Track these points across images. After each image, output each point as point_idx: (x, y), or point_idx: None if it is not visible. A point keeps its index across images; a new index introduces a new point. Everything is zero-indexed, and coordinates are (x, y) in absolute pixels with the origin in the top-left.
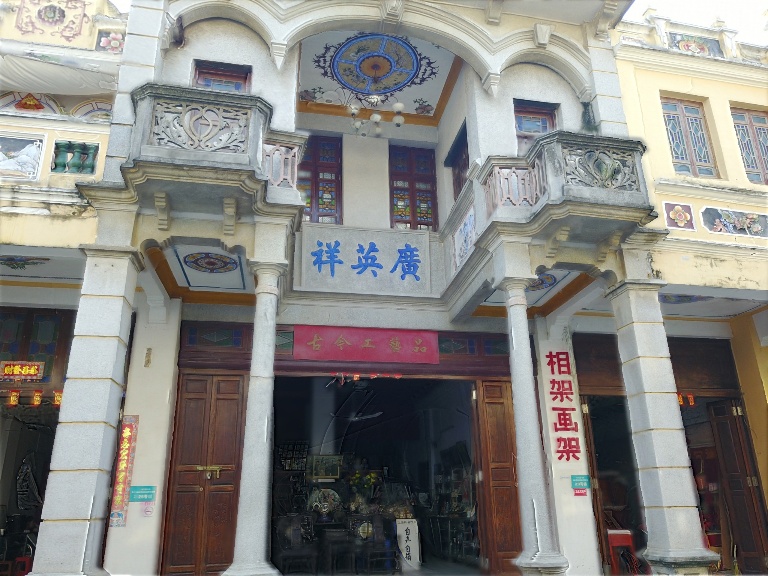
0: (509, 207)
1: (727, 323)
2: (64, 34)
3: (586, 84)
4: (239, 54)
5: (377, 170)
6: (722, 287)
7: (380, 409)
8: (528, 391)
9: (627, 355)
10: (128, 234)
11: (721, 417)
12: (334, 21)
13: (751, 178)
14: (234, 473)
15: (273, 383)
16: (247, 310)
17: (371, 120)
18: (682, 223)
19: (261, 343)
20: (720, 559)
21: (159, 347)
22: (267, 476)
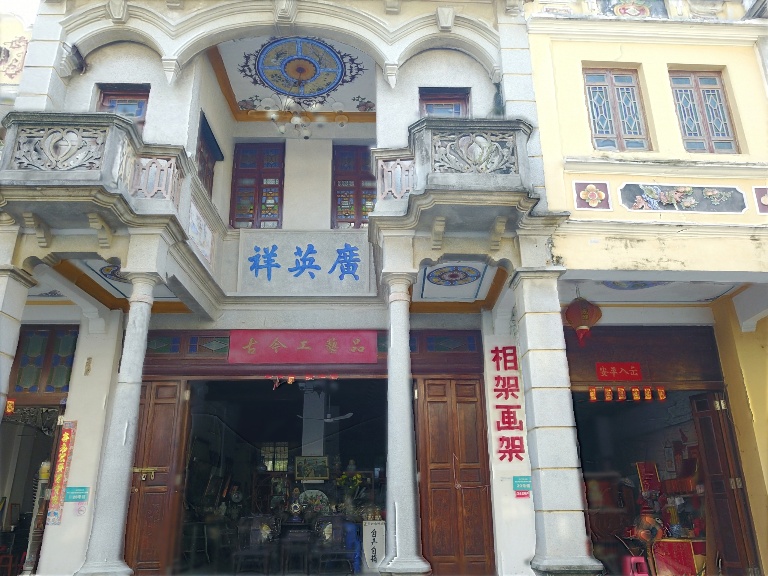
0: (389, 200)
1: (708, 308)
2: (8, 72)
3: (495, 64)
4: (139, 73)
5: (319, 172)
6: (637, 270)
7: (347, 410)
8: (400, 390)
9: (522, 348)
10: (9, 253)
11: (703, 412)
12: (228, 31)
13: (692, 147)
14: (168, 475)
15: (139, 388)
16: (185, 317)
17: (292, 123)
18: (595, 203)
19: (128, 350)
20: (704, 569)
21: (99, 356)
22: (123, 478)
